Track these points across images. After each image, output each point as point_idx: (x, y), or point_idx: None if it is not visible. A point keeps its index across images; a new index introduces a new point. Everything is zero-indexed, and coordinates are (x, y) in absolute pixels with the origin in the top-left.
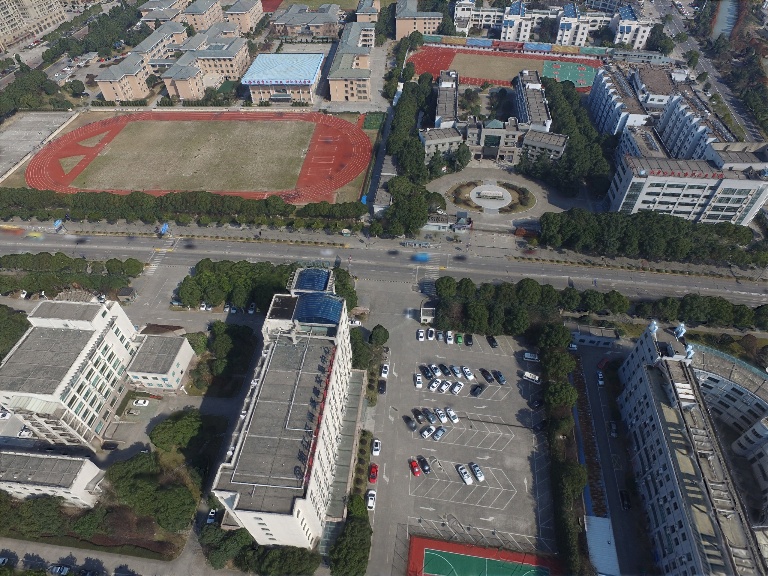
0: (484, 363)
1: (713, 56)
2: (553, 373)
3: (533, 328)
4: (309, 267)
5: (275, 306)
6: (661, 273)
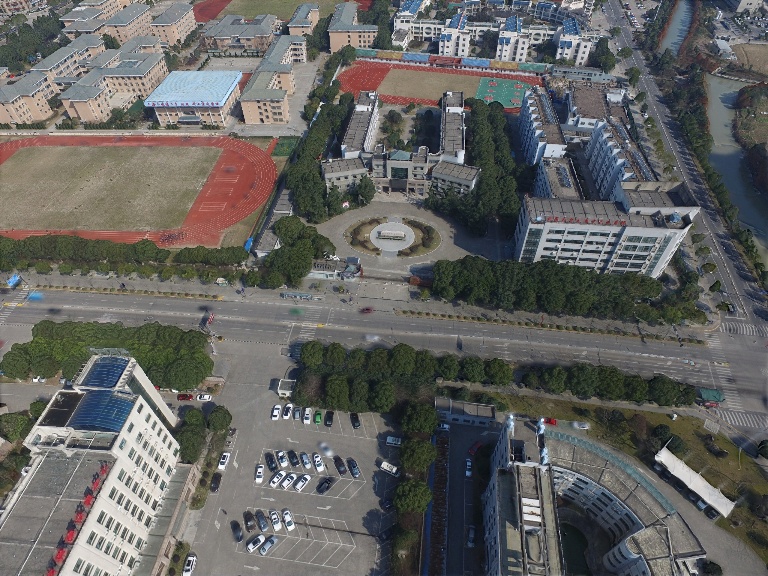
0: (341, 449)
1: (657, 73)
2: (409, 466)
3: (398, 407)
4: (158, 331)
5: (54, 406)
6: (561, 330)
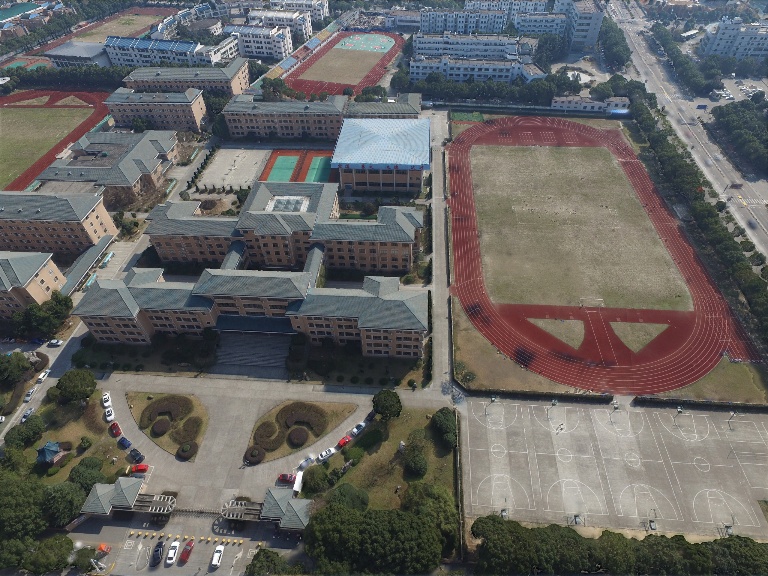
0: None
1: None
2: None
3: None
4: (731, 113)
5: None
6: None
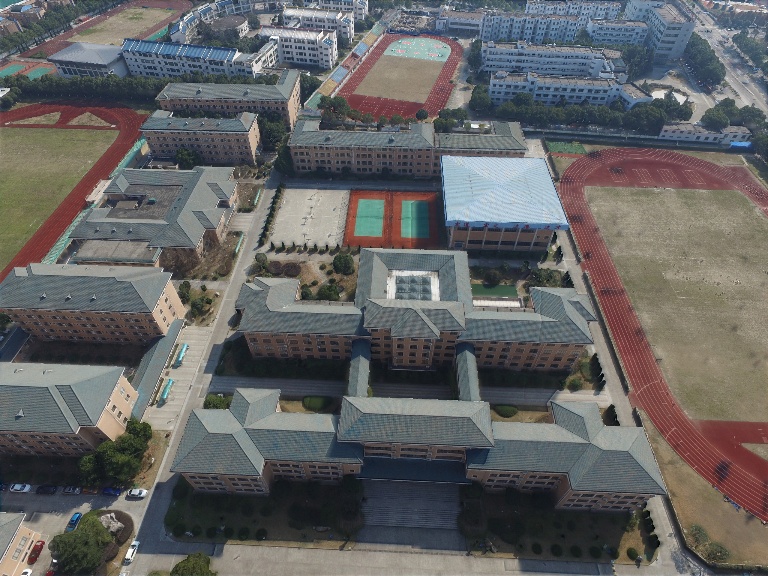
0: None
1: None
2: None
3: None
4: None
5: None
6: None
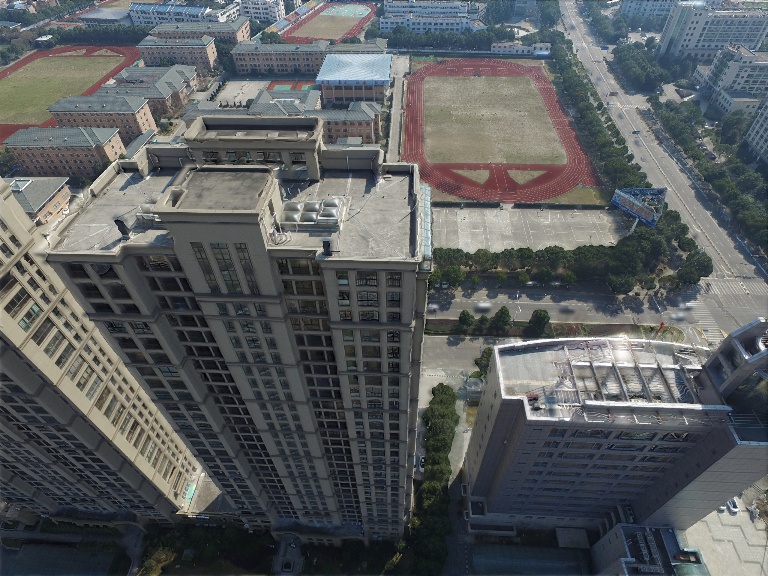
0: None
1: None
2: None
3: None
4: (624, 50)
5: None
6: None
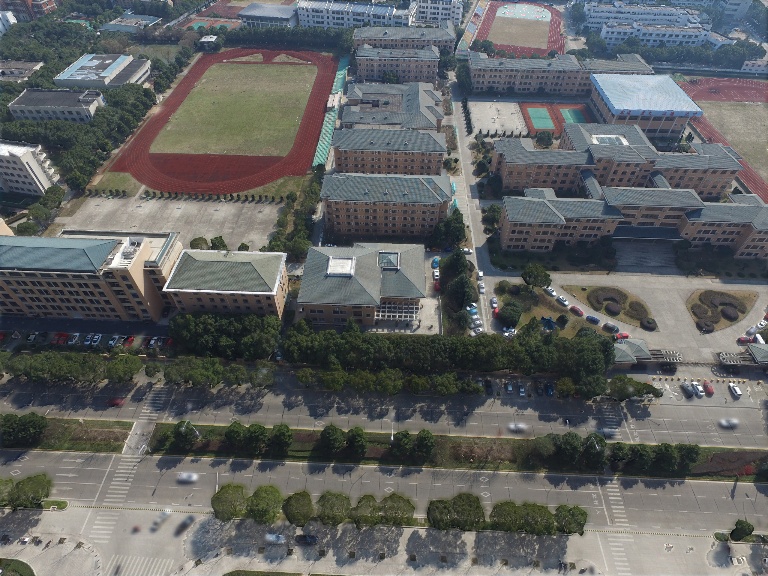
0: None
1: None
2: None
3: None
4: None
5: None
6: None
